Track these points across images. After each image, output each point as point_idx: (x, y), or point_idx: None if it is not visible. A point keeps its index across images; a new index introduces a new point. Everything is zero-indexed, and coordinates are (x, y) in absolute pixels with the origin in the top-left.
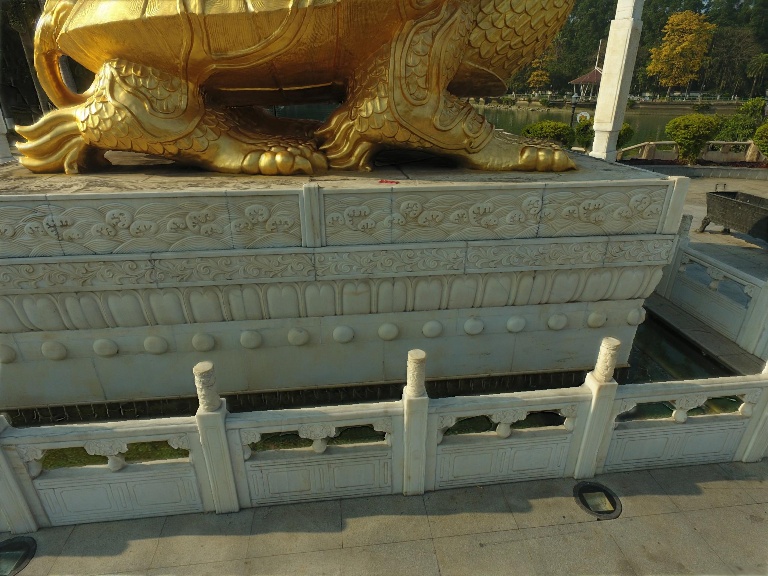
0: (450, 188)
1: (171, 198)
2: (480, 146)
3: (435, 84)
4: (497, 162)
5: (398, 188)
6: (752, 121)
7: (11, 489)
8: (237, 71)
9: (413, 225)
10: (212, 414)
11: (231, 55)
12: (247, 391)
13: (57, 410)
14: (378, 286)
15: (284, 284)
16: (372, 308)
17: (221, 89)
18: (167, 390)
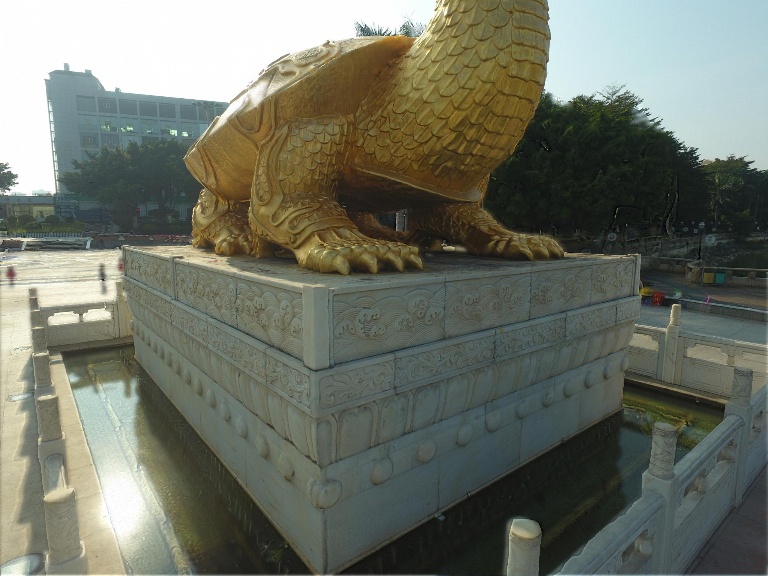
0: (203, 267)
1: (152, 257)
2: (298, 242)
3: None
4: None
5: (190, 263)
6: None
7: None
8: (222, 189)
9: None
10: None
11: None
12: (170, 398)
13: None
14: None
15: None
16: None
17: (240, 201)
18: (158, 379)
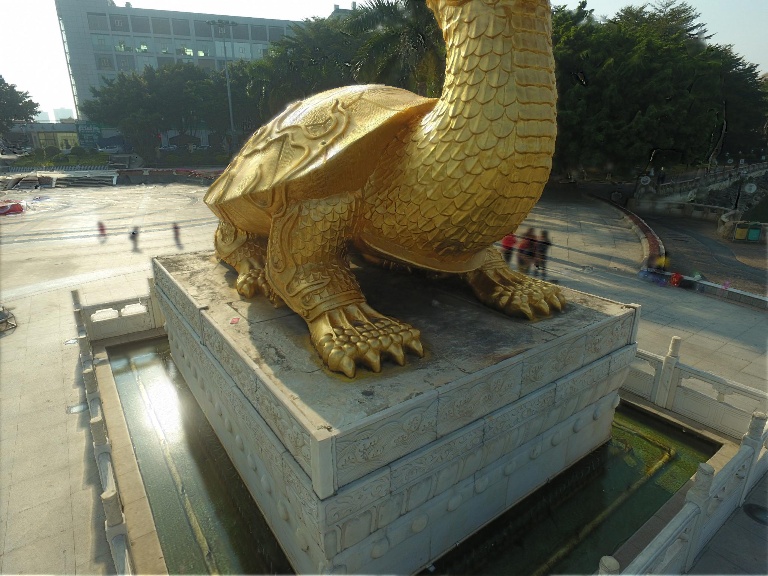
0: None
1: None
2: (310, 318)
3: None
4: None
5: None
6: None
7: None
8: None
9: None
10: None
11: None
12: None
13: None
14: None
15: None
16: None
17: None
18: None
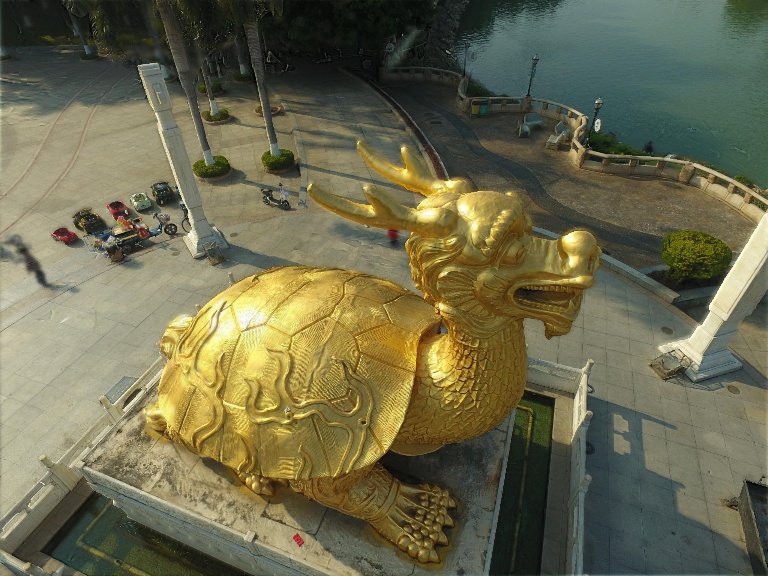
0: (321, 572)
1: None
2: (374, 521)
3: None
4: (384, 533)
5: (292, 559)
6: None
7: None
8: None
9: None
10: None
11: None
12: (237, 567)
13: (159, 534)
14: None
15: None
16: None
17: None
18: (202, 549)
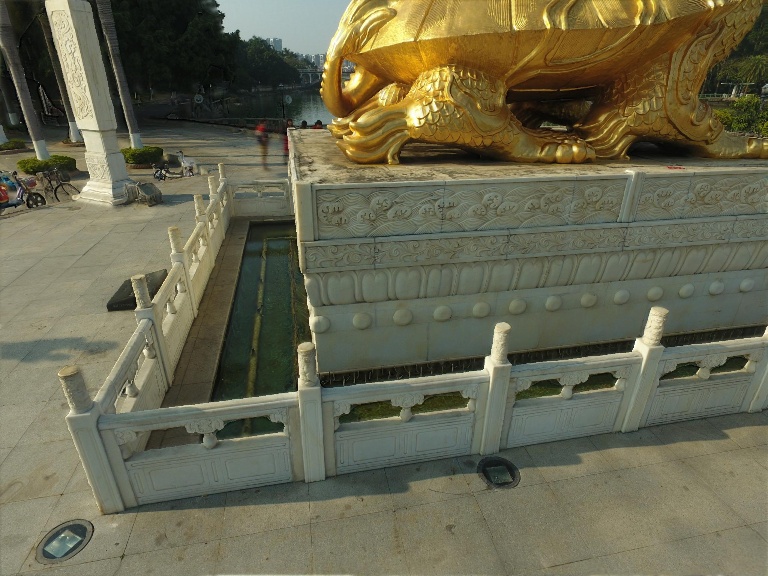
0: (735, 172)
1: (535, 182)
2: (717, 138)
3: None
4: (728, 151)
5: (699, 172)
6: (746, 116)
7: (501, 415)
8: (551, 75)
9: (700, 203)
10: (659, 347)
11: (565, 62)
12: (536, 349)
13: (390, 371)
14: (661, 255)
15: (596, 254)
16: (649, 274)
17: (513, 90)
18: (476, 350)
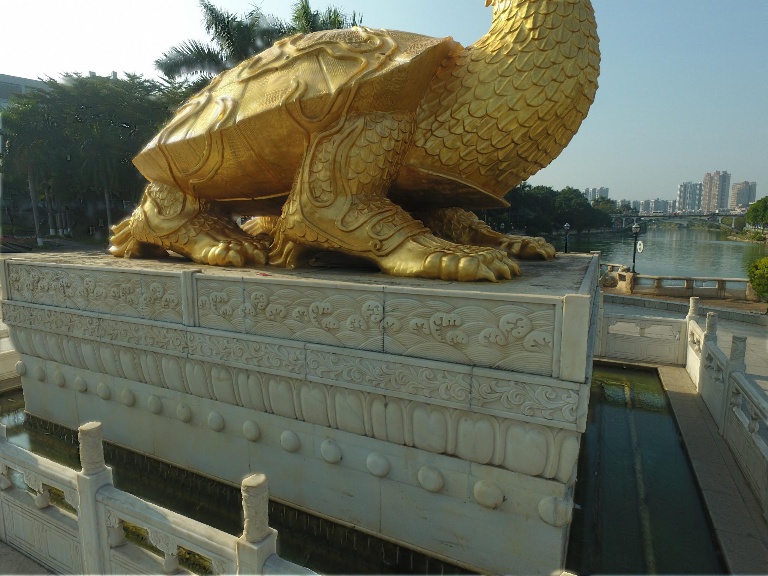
0: (290, 282)
1: (114, 272)
2: (387, 249)
3: (342, 188)
4: (403, 267)
5: (248, 278)
6: None
7: None
8: (207, 184)
9: (263, 317)
10: None
11: (190, 172)
12: (152, 455)
13: (56, 427)
14: (237, 376)
15: (171, 357)
16: None
17: (217, 200)
18: (109, 434)
